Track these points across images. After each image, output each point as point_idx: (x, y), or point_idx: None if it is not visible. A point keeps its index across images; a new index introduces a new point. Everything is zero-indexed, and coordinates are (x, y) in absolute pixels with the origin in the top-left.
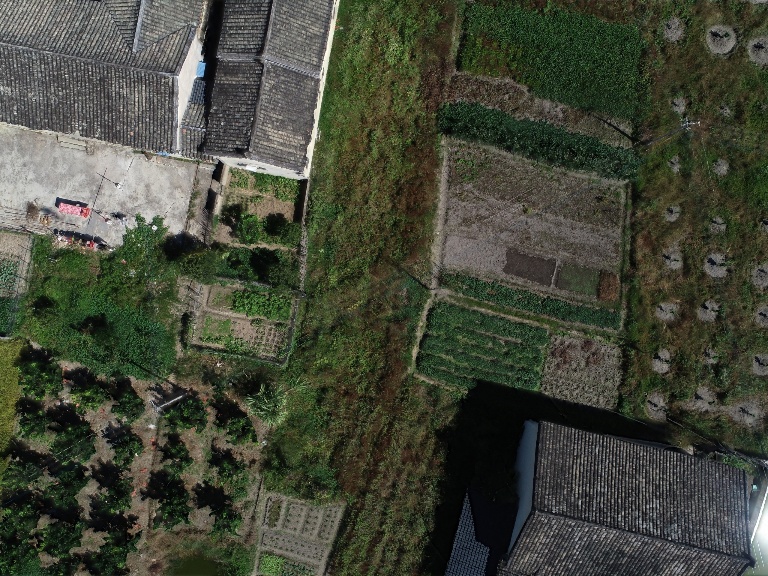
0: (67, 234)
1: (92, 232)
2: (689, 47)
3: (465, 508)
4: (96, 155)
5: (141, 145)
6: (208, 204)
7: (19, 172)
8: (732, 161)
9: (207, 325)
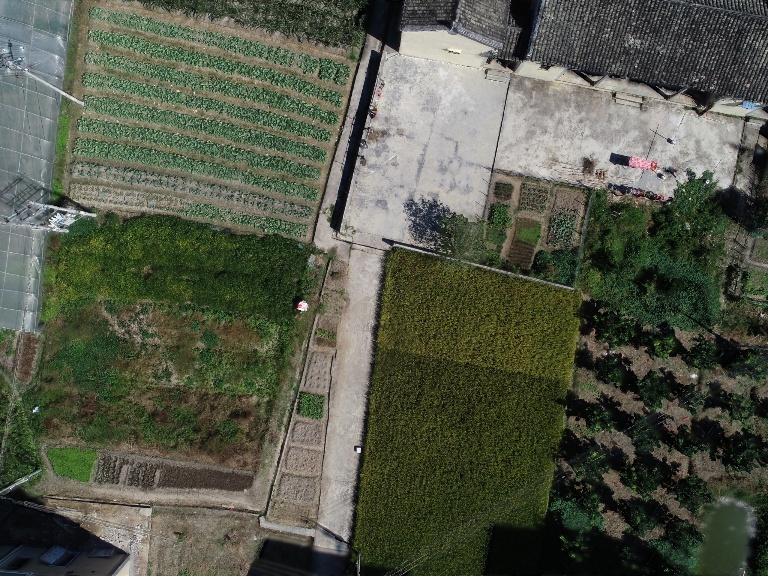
0: (621, 189)
1: (644, 187)
2: None
3: None
4: (649, 112)
5: (753, 97)
6: (755, 159)
7: (576, 128)
8: None
9: (750, 277)
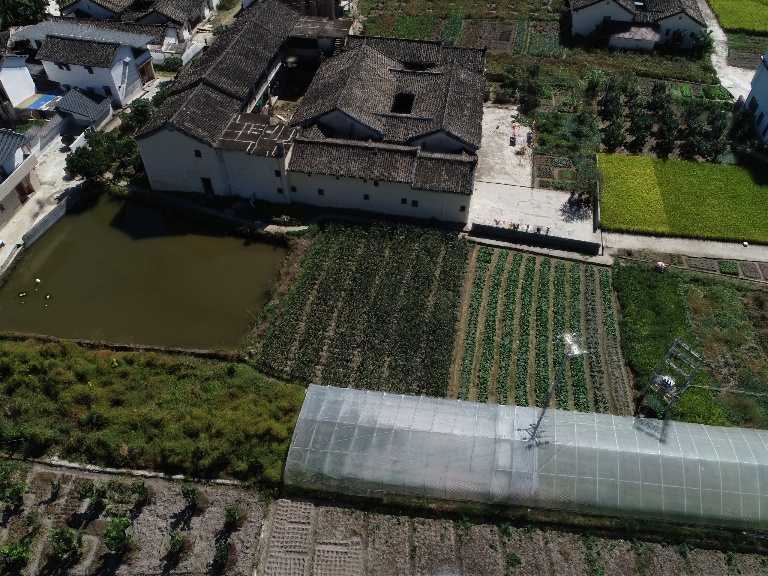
0: (529, 143)
1: None
2: (406, 8)
3: (618, 36)
4: (483, 134)
5: None
6: (500, 104)
7: None
8: (450, 3)
9: None
